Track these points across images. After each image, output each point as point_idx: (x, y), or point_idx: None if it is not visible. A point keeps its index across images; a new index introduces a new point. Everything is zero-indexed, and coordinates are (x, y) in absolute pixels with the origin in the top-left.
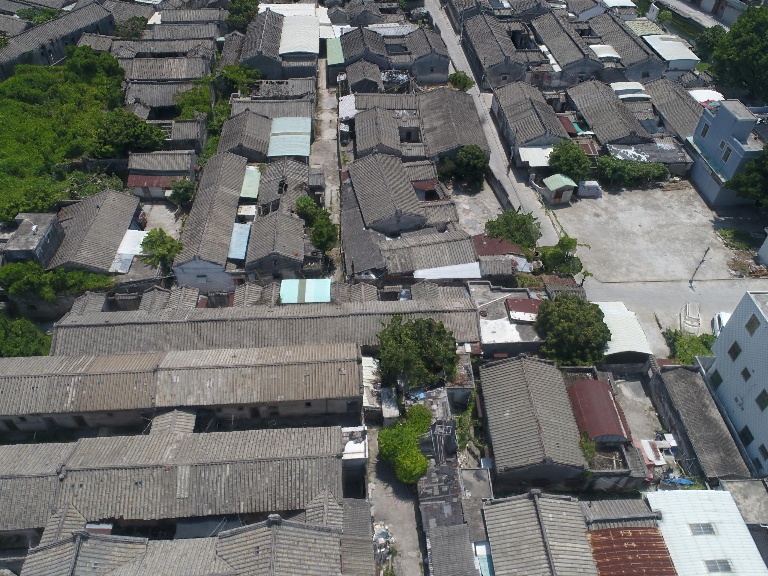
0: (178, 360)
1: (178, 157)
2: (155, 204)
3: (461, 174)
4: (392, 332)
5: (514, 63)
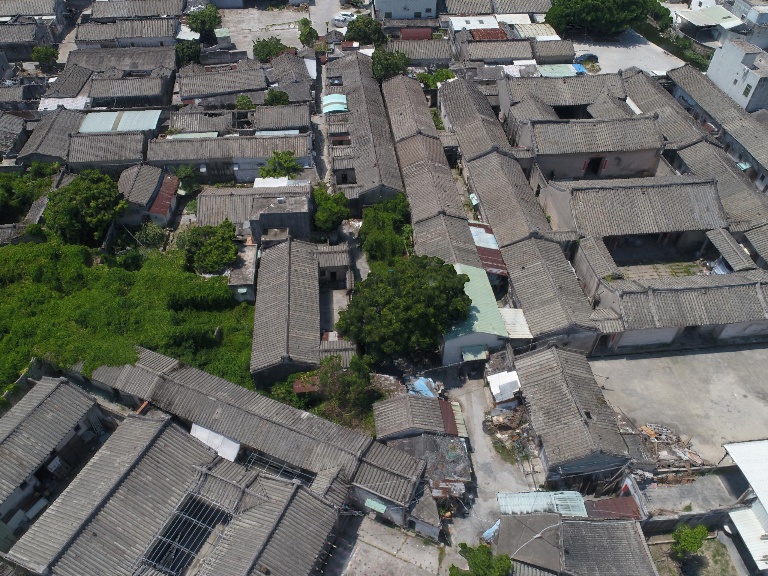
0: (407, 131)
1: (142, 172)
2: (182, 213)
3: (198, 63)
4: (386, 60)
5: (40, 25)
